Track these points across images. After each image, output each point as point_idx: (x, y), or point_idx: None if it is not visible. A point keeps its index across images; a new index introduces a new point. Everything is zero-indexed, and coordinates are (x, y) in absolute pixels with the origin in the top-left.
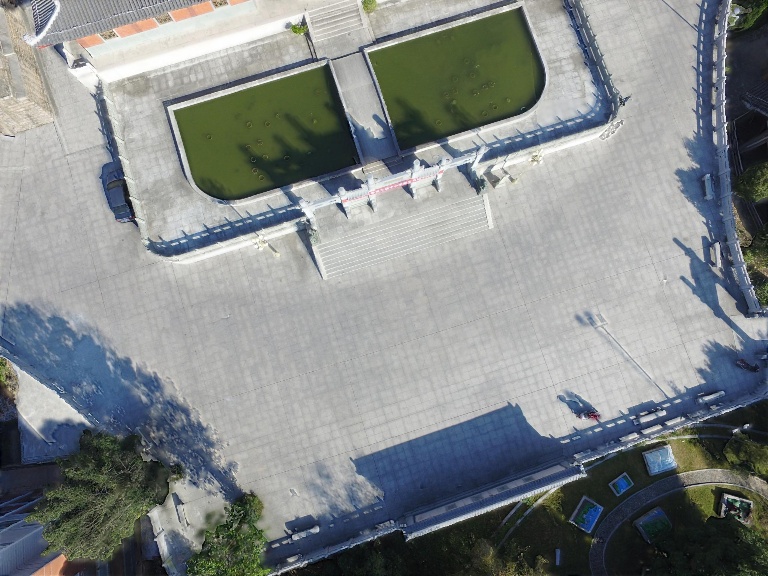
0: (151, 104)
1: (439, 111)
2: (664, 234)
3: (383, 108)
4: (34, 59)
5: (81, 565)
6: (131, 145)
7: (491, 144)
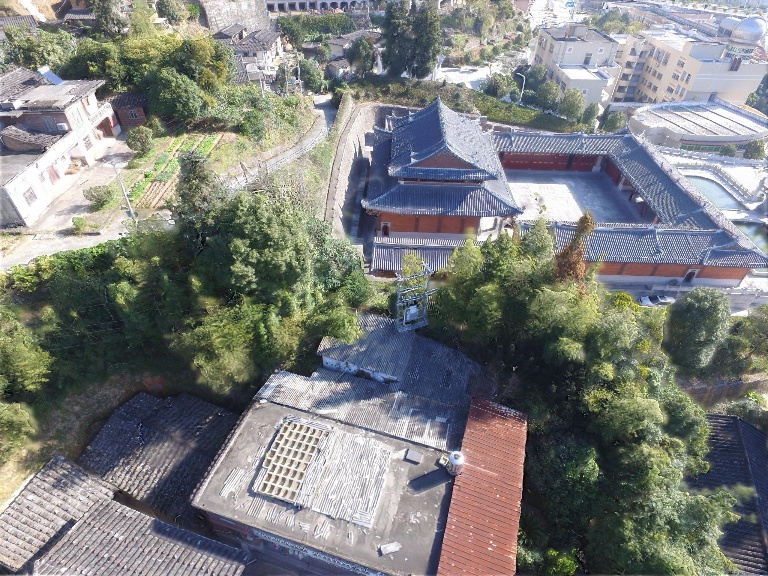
0: None
1: (723, 201)
2: (754, 174)
3: (732, 210)
4: None
5: None
6: None
7: (735, 194)
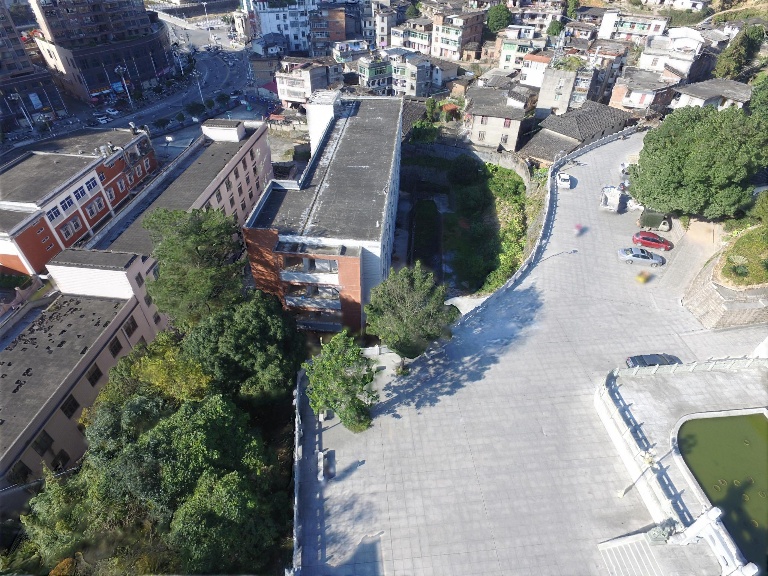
0: (760, 396)
1: None
2: None
3: None
4: (762, 322)
5: (345, 311)
6: (709, 375)
7: None
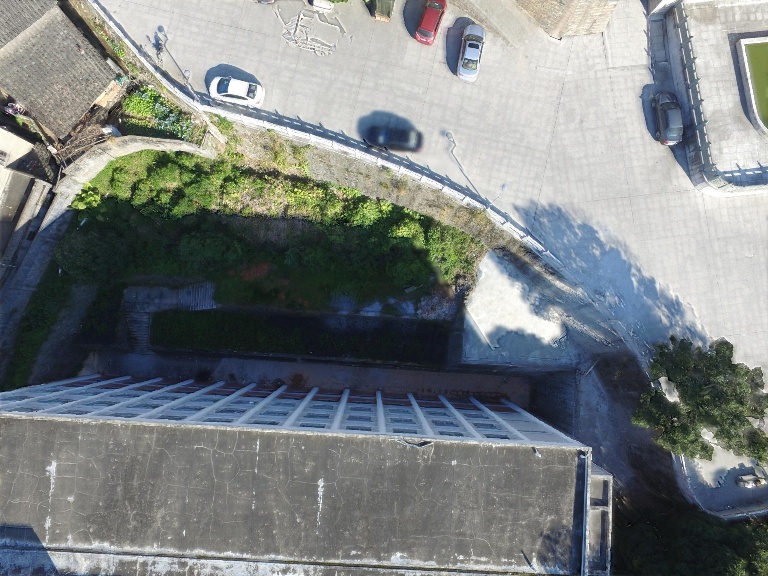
0: (716, 34)
1: None
2: None
3: None
4: None
5: None
6: None
7: None
